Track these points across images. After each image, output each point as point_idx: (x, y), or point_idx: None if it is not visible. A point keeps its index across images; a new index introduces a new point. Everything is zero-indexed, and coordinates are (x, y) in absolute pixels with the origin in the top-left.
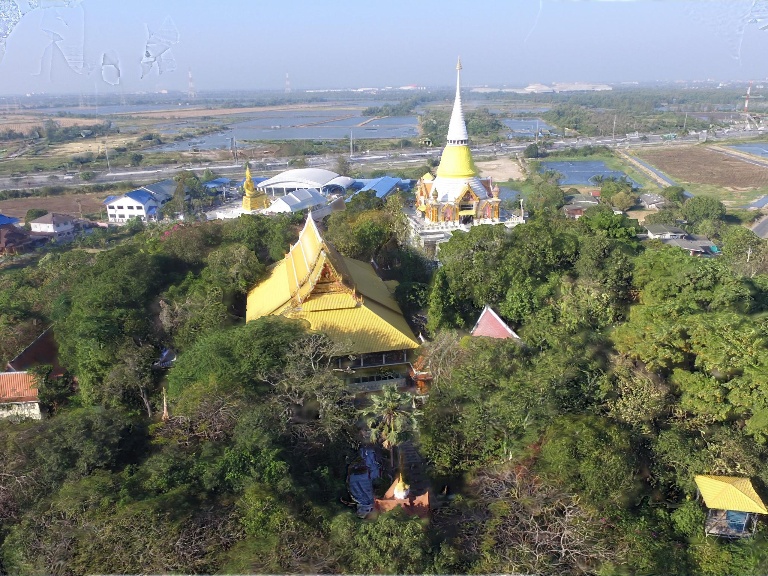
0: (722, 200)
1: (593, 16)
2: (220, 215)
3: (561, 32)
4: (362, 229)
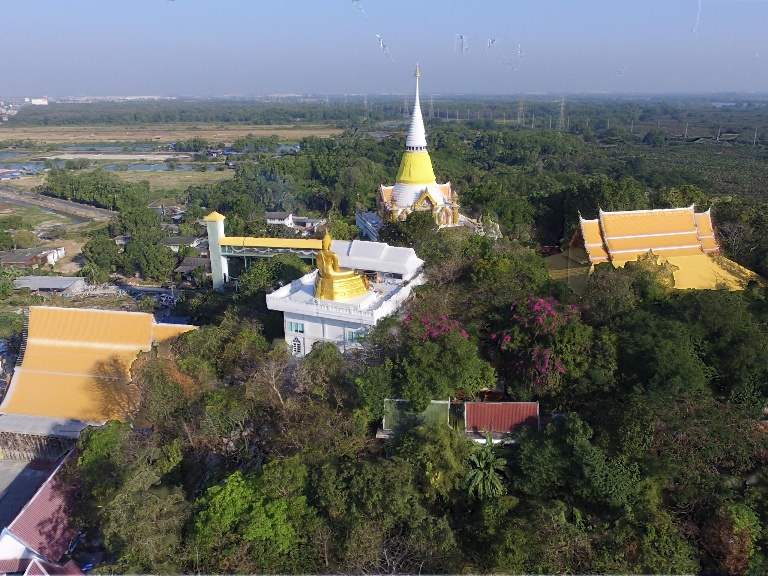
0: (41, 222)
1: None
2: (378, 314)
3: None
4: (483, 243)
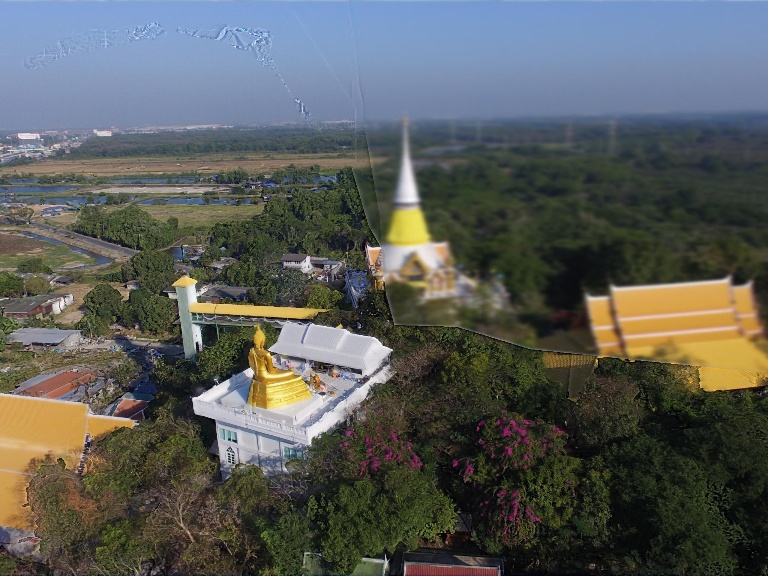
0: (64, 263)
1: None
2: (314, 431)
3: None
4: None
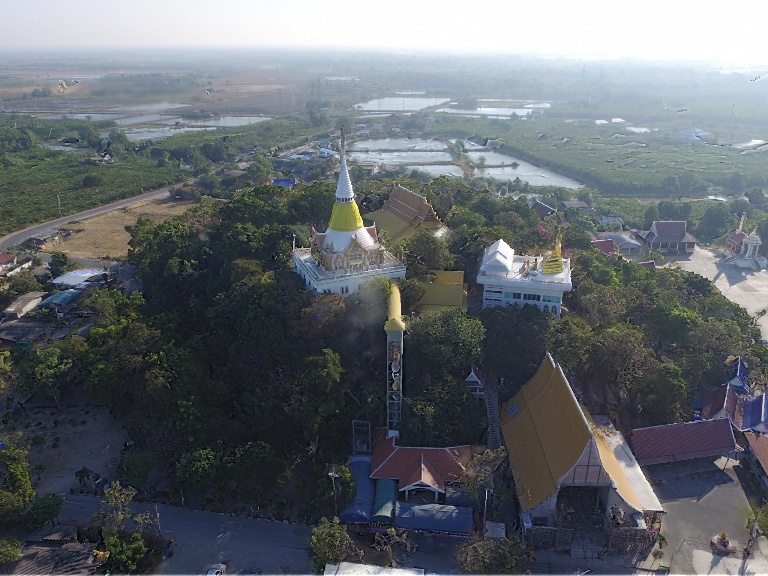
0: None
1: (311, 98)
2: None
3: (317, 101)
4: None
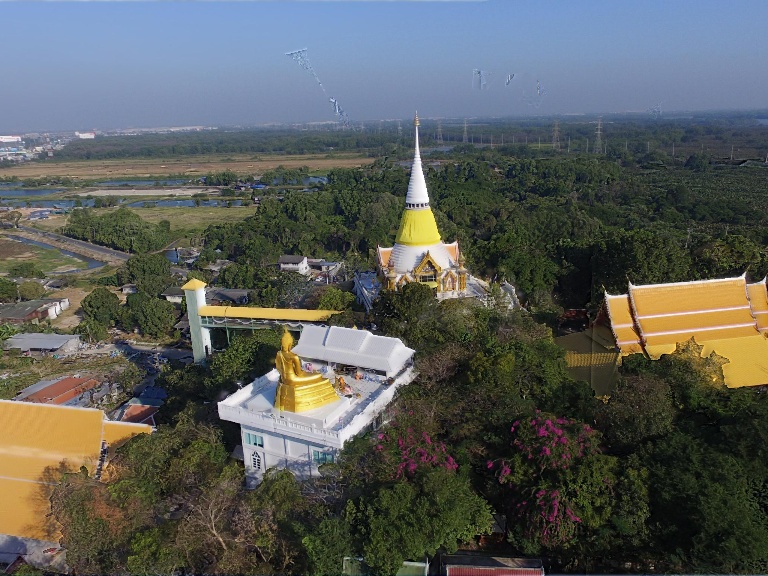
0: (56, 267)
1: None
2: (345, 434)
3: None
4: (491, 318)
